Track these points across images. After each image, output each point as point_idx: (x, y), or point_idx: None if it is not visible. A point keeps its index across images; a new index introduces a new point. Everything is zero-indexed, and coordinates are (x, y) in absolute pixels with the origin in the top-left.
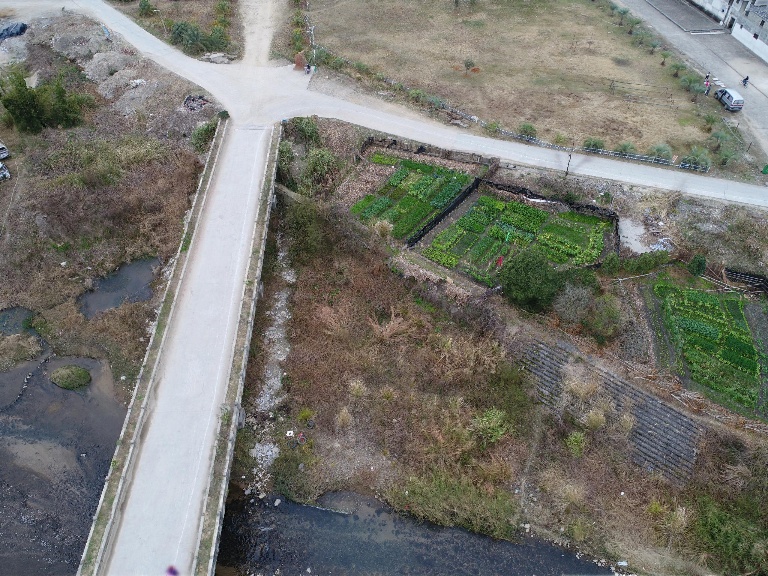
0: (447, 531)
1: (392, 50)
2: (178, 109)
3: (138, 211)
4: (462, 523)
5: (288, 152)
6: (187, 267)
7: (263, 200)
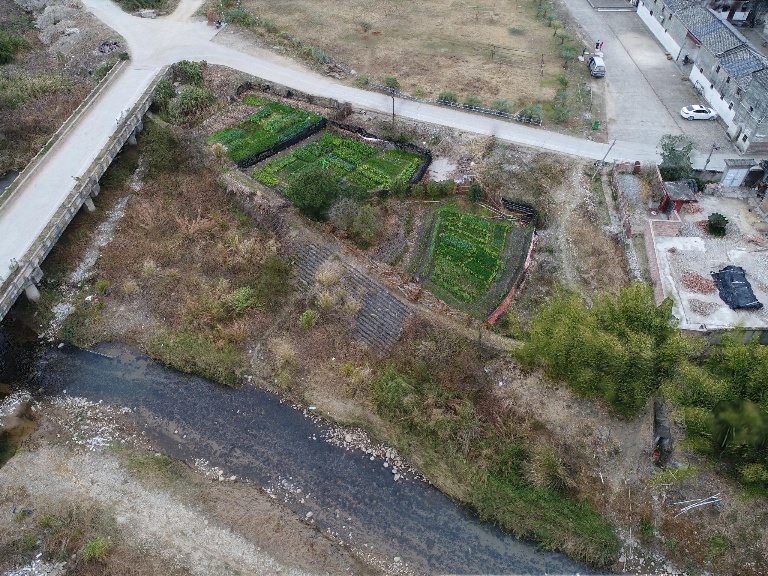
0: (186, 376)
1: (309, 14)
2: (91, 51)
3: (34, 131)
4: (199, 371)
5: (167, 89)
6: (40, 167)
7: (122, 121)
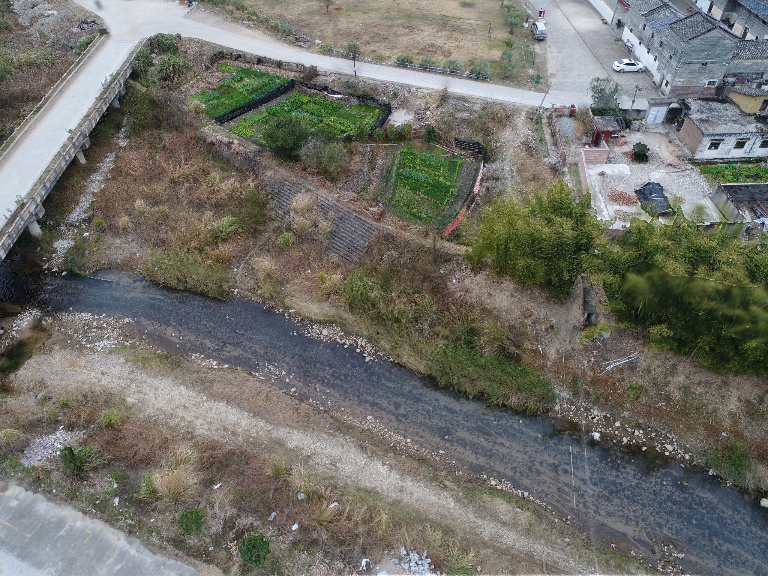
0: (179, 293)
1: None
2: (71, 29)
3: (22, 100)
4: (191, 288)
5: (146, 58)
6: (33, 125)
7: (107, 85)
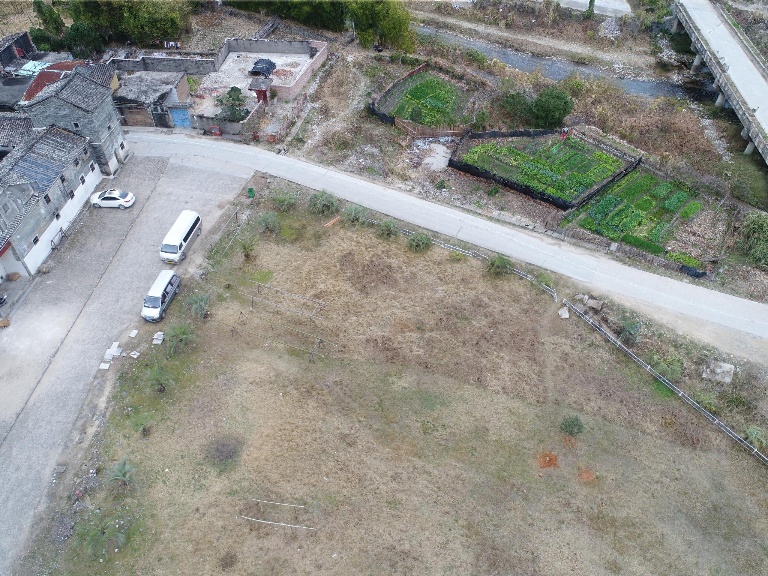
0: None
1: None
2: None
3: None
4: None
5: None
6: None
7: None
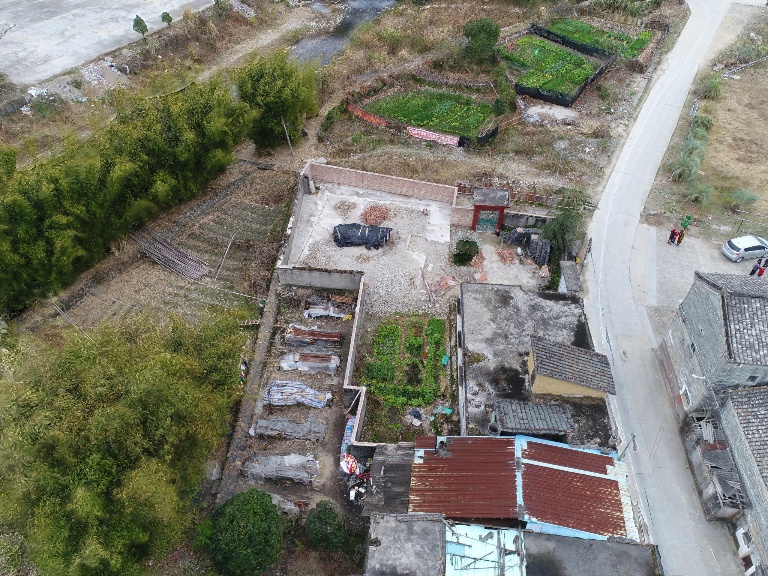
0: None
1: None
2: None
3: None
4: None
5: None
6: None
7: None
